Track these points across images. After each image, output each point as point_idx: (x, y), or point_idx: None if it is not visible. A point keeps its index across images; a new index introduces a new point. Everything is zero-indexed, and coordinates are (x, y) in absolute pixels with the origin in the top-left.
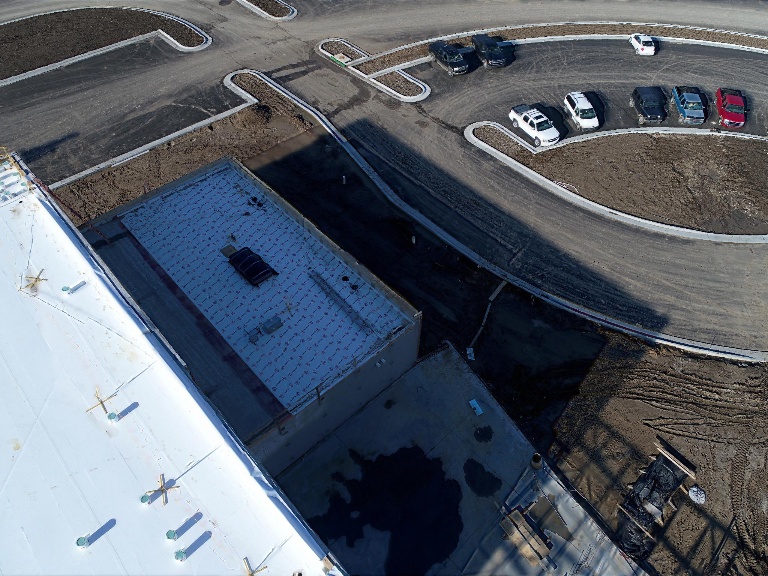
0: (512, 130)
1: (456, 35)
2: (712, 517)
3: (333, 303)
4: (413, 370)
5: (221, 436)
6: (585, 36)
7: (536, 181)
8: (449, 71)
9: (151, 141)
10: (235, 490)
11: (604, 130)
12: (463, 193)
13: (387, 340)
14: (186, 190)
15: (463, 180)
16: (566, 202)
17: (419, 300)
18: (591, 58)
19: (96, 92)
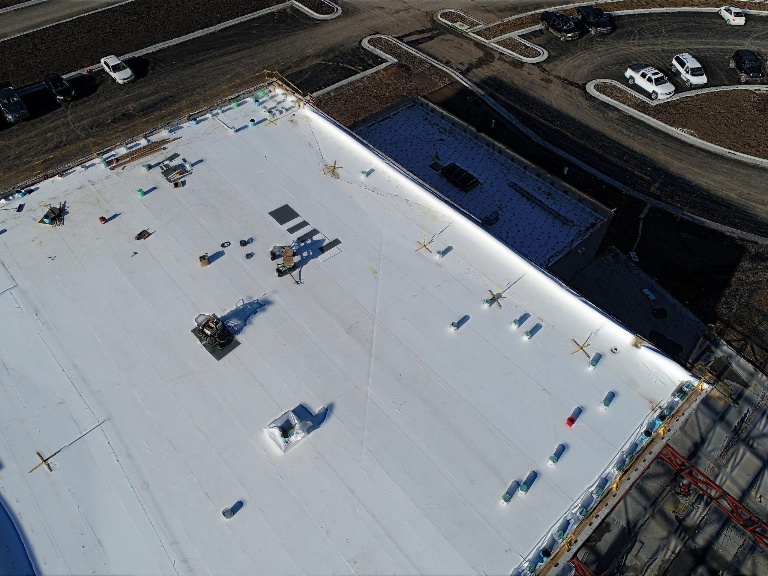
0: (628, 86)
1: (560, 7)
2: None
3: (535, 205)
4: (590, 267)
5: (530, 264)
6: (677, 9)
7: (659, 127)
8: (562, 37)
9: (314, 92)
10: (548, 300)
11: (711, 87)
12: (597, 136)
13: (587, 231)
14: (384, 121)
15: (594, 126)
16: (688, 144)
17: None
18: (687, 27)
19: (252, 52)
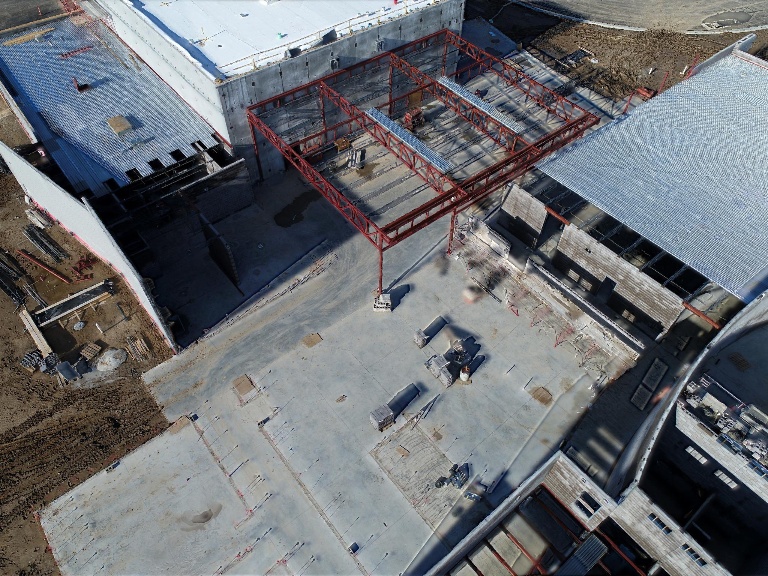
0: None
1: None
2: (599, 66)
3: None
4: None
5: None
6: None
7: None
8: None
9: None
10: None
11: None
12: None
13: None
14: None
15: None
16: None
17: None
18: None
19: None
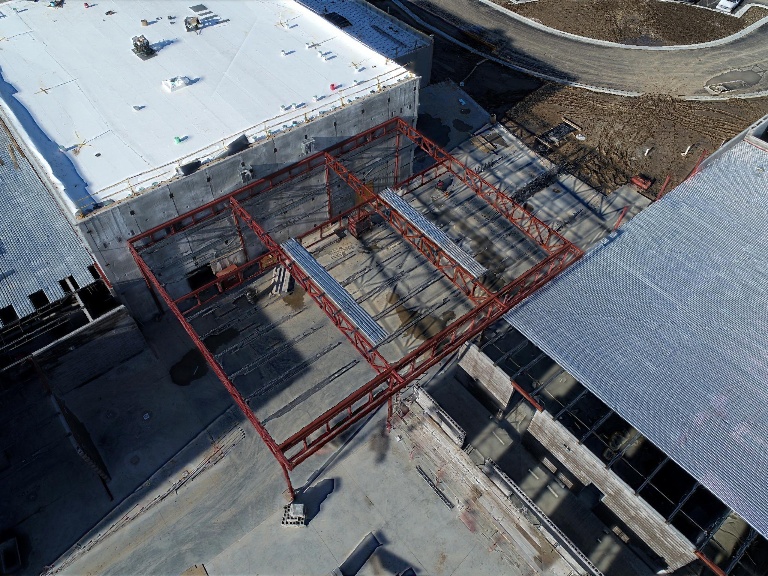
0: None
1: None
2: (586, 145)
3: (384, 37)
4: (427, 87)
5: (339, 30)
6: None
7: (515, 17)
8: None
9: None
10: (346, 47)
11: None
12: (466, 21)
13: None
14: None
15: (466, 15)
16: (533, 27)
17: (433, 63)
18: None
19: None
